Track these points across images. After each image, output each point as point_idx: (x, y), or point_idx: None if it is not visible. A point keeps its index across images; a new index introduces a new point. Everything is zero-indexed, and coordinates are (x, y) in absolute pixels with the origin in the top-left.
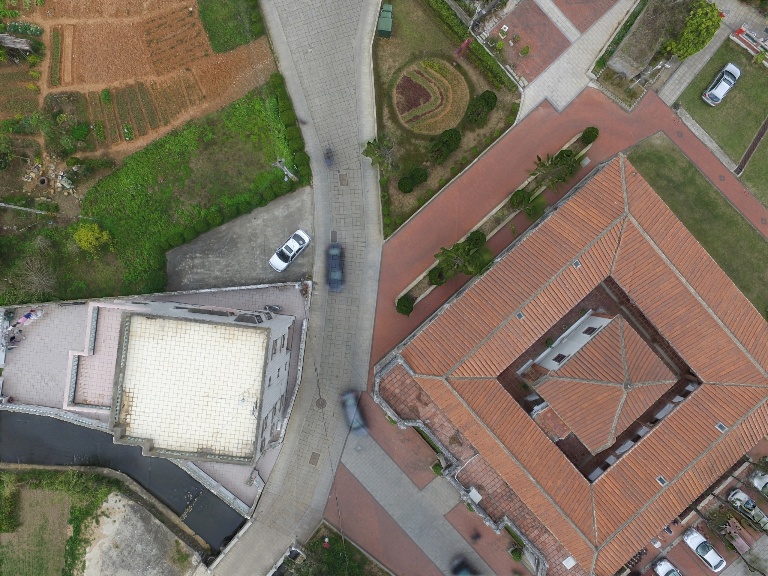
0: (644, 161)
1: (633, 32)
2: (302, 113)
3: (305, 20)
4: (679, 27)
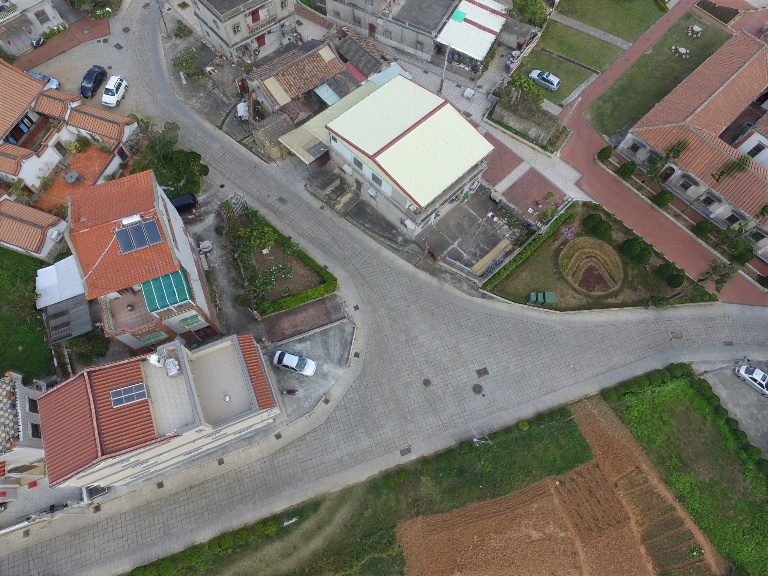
0: (604, 124)
1: (536, 124)
2: (629, 372)
3: (546, 370)
4: (535, 96)
